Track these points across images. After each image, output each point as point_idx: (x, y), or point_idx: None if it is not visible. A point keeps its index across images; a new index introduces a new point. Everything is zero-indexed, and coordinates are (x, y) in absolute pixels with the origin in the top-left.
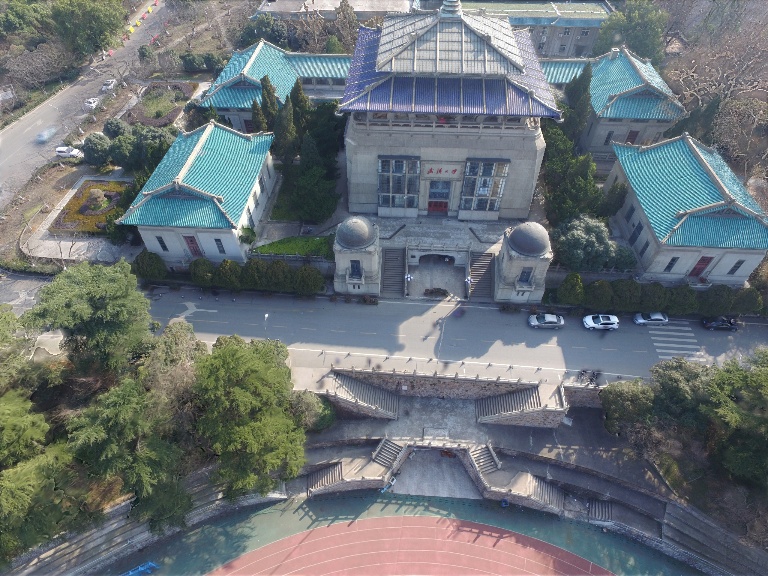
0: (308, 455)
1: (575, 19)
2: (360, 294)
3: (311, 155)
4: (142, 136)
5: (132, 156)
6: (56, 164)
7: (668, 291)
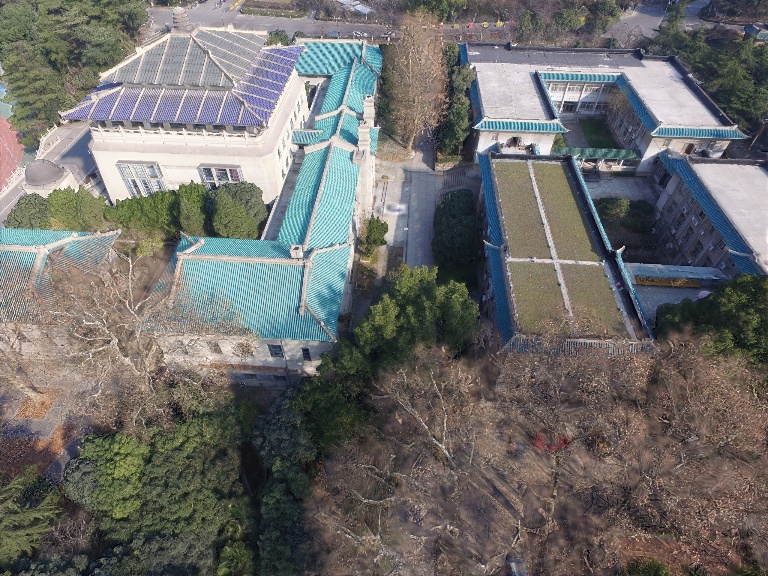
0: None
1: None
2: None
3: None
4: None
5: None
6: None
7: None
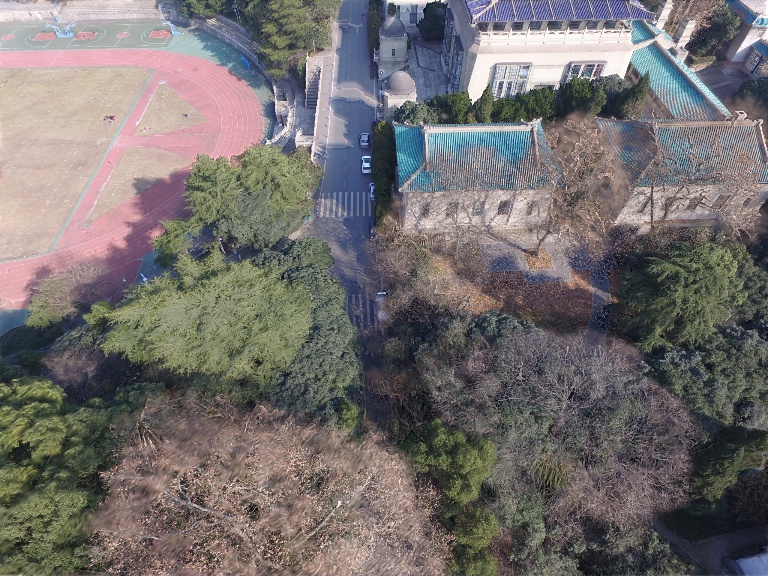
0: (291, 91)
1: None
2: None
3: None
4: None
5: None
6: None
7: (383, 174)
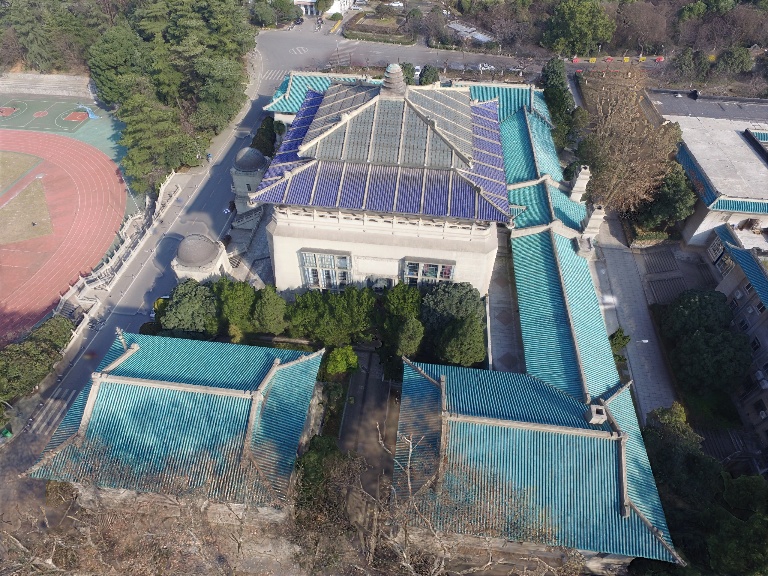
0: None
1: None
2: None
3: None
4: None
5: None
6: None
7: None
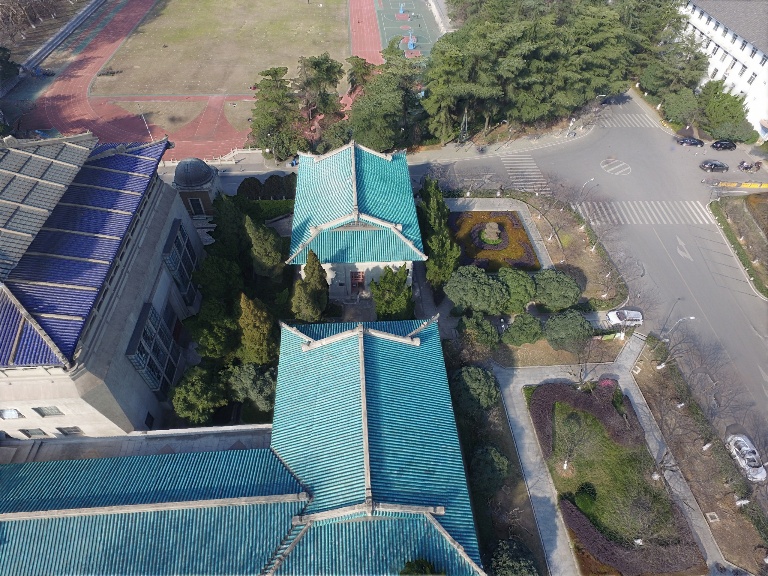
0: None
1: None
2: None
3: None
4: None
5: None
6: (616, 297)
7: None
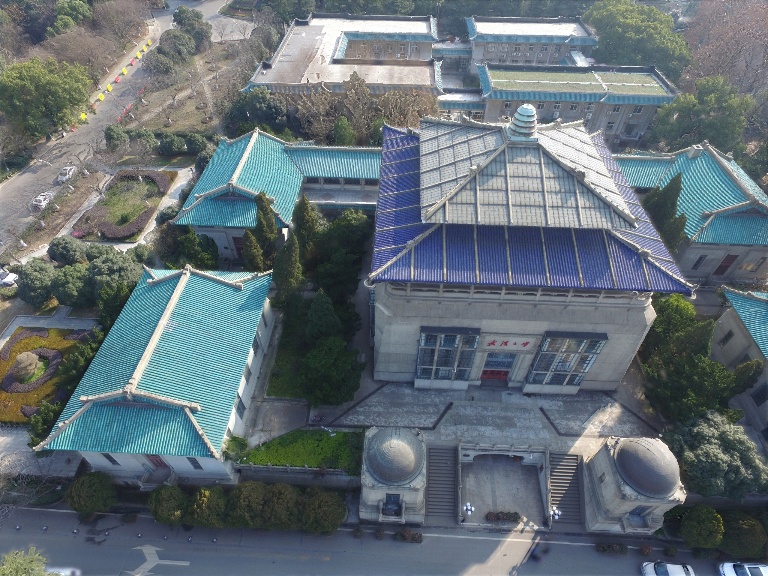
0: None
1: (627, 95)
2: (396, 522)
3: (325, 318)
4: (96, 268)
5: (82, 294)
6: None
7: None
